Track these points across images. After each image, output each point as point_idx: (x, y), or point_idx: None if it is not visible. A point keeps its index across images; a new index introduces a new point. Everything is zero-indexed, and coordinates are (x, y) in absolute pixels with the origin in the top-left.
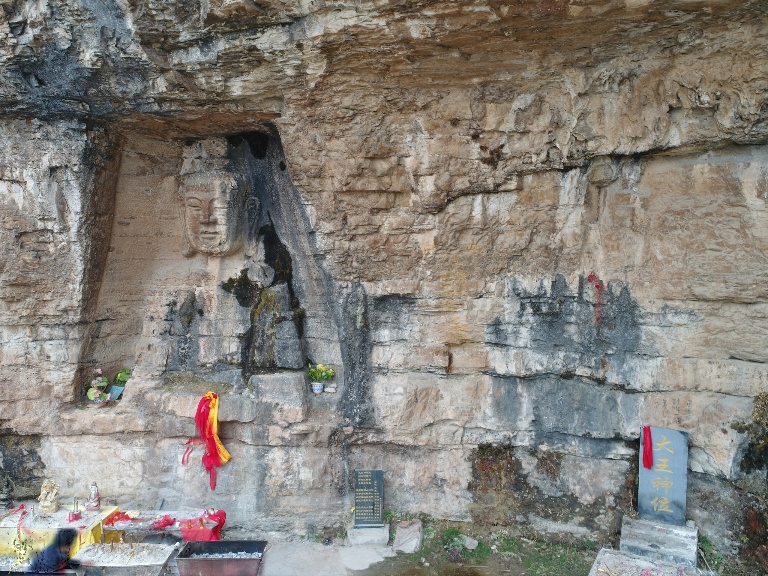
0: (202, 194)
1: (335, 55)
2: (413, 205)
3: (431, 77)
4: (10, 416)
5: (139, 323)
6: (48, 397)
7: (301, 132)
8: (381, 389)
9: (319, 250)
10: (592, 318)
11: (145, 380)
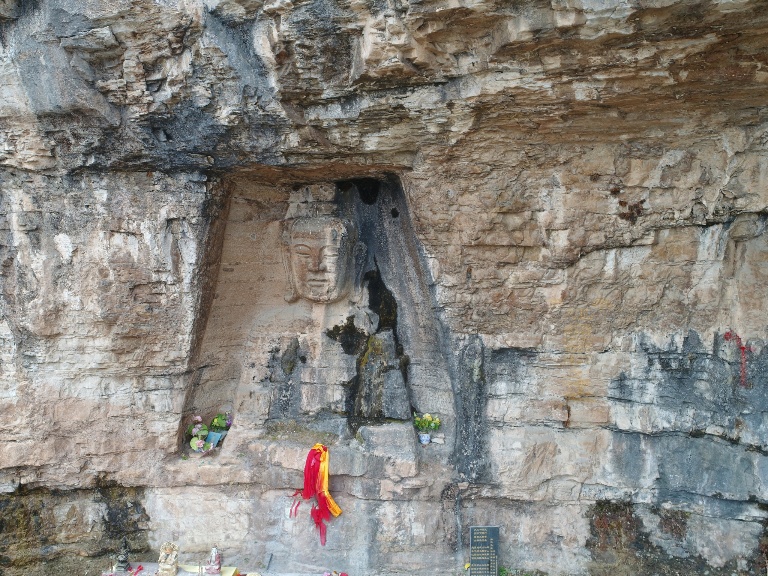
0: (312, 242)
1: (485, 114)
2: (543, 259)
3: (579, 134)
4: (116, 468)
5: (236, 367)
6: (153, 448)
7: (434, 187)
8: (498, 444)
9: (439, 303)
10: (728, 377)
11: (248, 429)
